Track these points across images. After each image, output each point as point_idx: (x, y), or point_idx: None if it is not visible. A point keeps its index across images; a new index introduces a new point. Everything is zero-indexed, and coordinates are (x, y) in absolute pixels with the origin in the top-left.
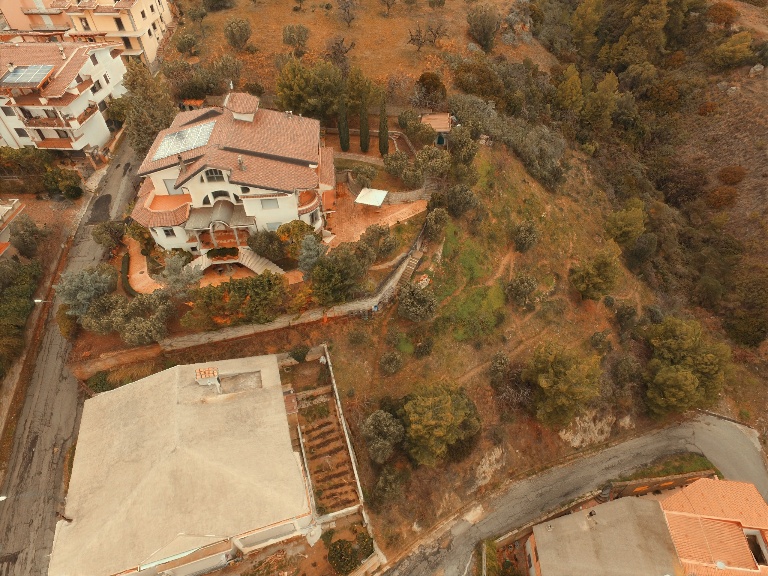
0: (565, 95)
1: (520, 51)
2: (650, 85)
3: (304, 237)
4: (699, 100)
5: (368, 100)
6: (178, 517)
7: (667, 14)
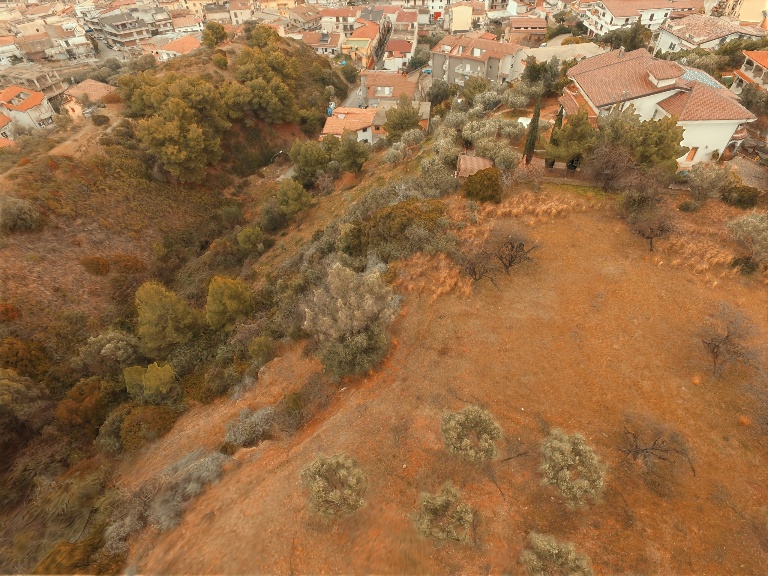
0: None
1: (241, 408)
2: None
3: None
4: None
5: None
6: None
7: None
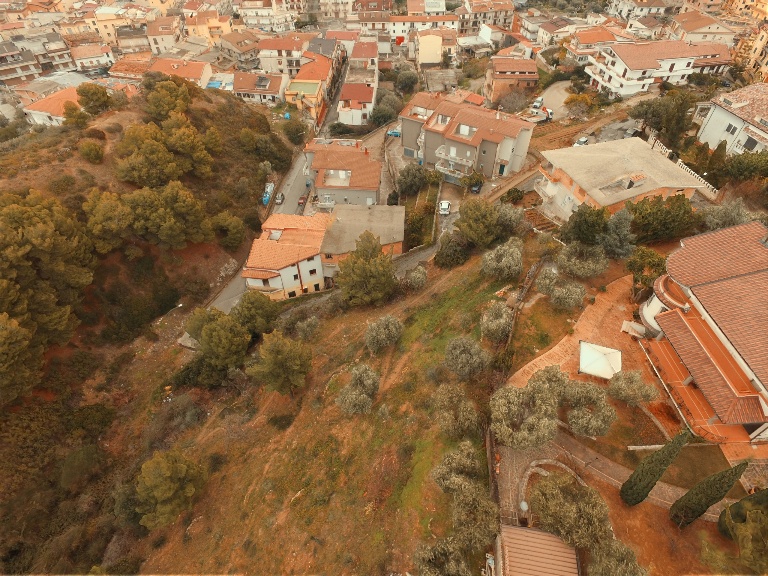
0: None
1: None
2: None
3: None
4: None
5: (742, 529)
6: (602, 147)
7: None
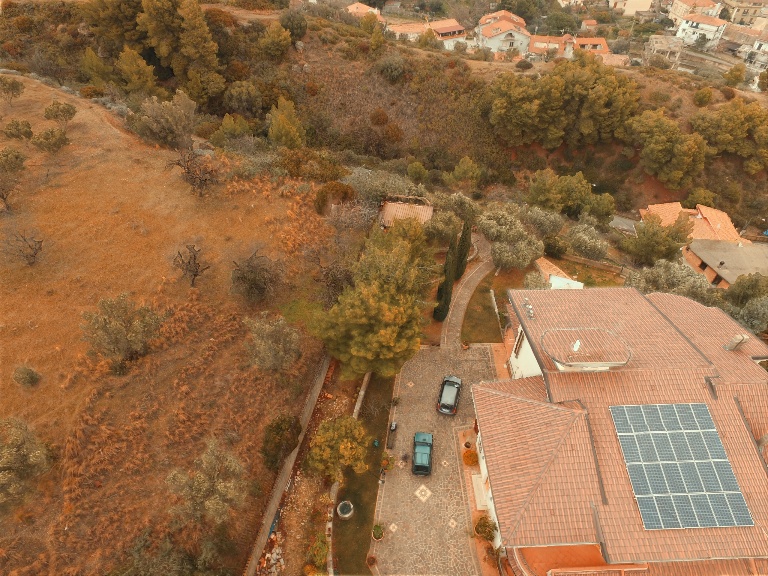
0: (291, 137)
1: None
2: (259, 98)
3: (763, 309)
4: (298, 87)
5: None
6: None
7: (209, 33)
